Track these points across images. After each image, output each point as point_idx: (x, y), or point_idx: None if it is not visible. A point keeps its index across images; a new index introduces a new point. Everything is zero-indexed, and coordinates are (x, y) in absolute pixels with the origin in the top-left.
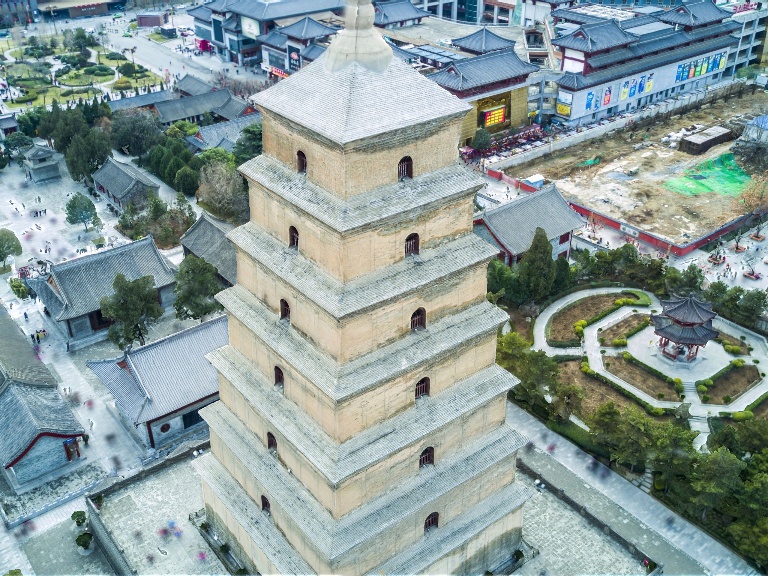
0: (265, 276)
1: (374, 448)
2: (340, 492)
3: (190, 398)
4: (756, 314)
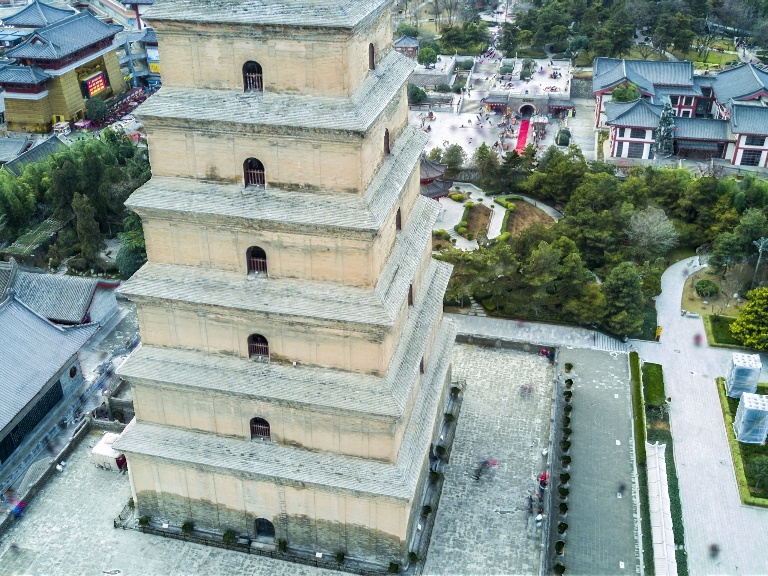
0: (212, 142)
1: (397, 285)
2: (384, 343)
3: (3, 419)
4: (459, 165)
